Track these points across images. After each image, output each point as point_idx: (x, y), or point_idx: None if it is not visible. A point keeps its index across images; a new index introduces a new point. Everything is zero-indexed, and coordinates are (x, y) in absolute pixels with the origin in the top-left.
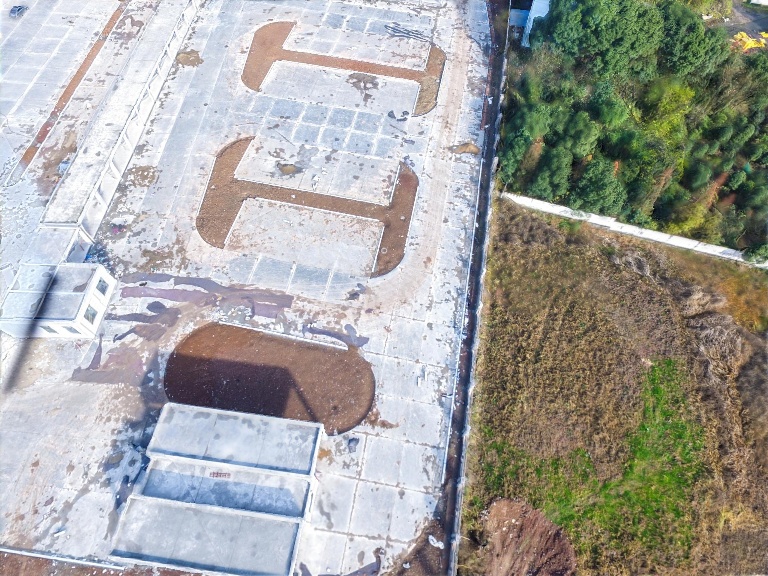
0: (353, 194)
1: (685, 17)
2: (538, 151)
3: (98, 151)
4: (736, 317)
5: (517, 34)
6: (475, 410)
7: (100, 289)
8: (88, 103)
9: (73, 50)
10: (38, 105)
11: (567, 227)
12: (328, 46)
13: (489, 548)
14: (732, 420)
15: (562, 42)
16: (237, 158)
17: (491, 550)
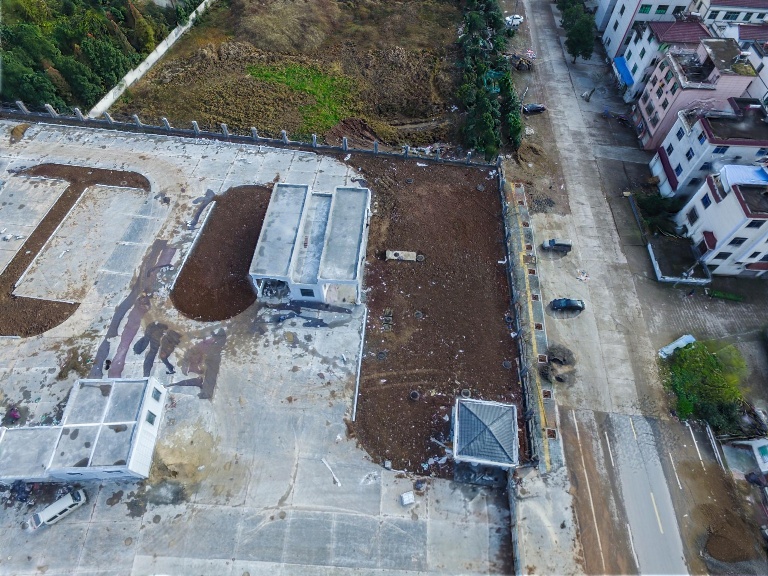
0: (45, 207)
1: None
2: (56, 71)
3: None
4: None
5: None
6: None
7: None
8: None
9: None
10: None
11: (129, 99)
12: None
13: None
14: None
15: None
16: None
17: None
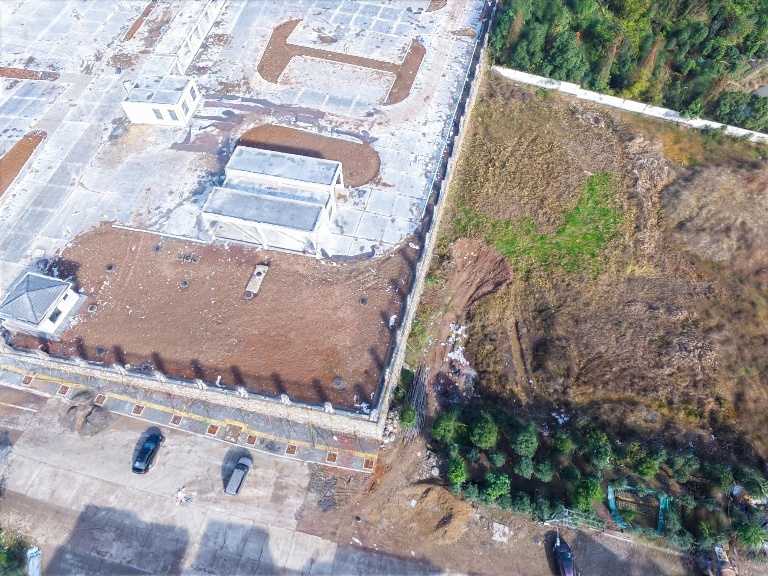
0: (375, 56)
1: None
2: (518, 25)
3: (190, 15)
4: (669, 157)
5: None
6: (452, 187)
7: (191, 95)
8: None
9: None
10: None
11: (542, 94)
12: None
13: (453, 267)
14: (650, 215)
15: None
16: (289, 31)
17: (454, 268)
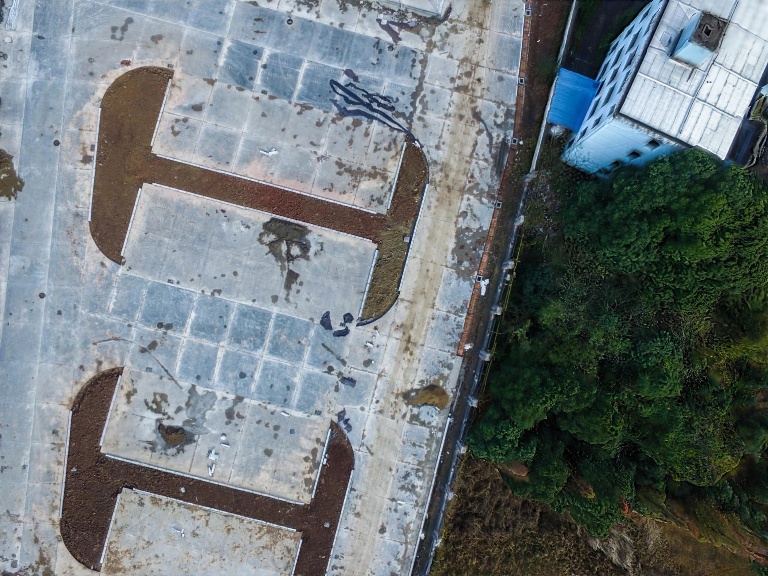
0: (263, 484)
1: None
2: None
3: None
4: None
5: None
6: None
7: None
8: None
9: None
10: None
11: None
12: (229, 145)
13: None
14: None
15: None
16: (101, 416)
17: None
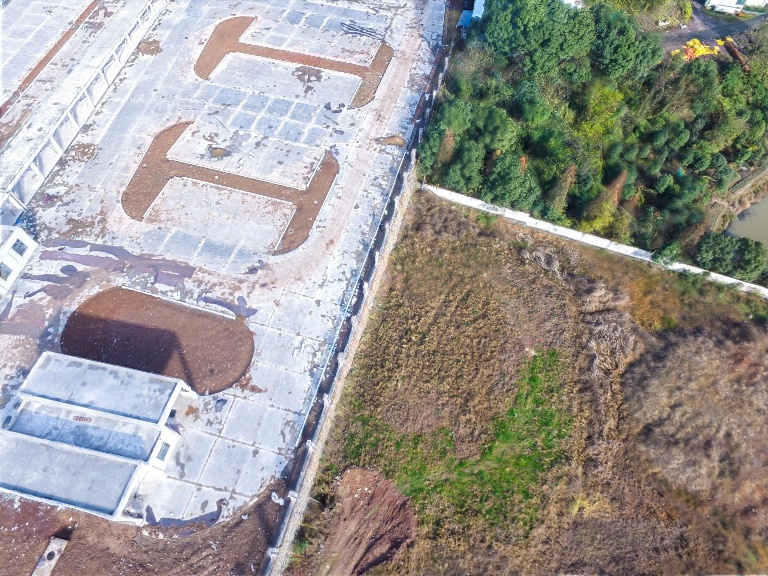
0: (273, 178)
1: (615, 20)
2: (450, 144)
3: (40, 127)
4: (636, 316)
5: (465, 34)
6: (347, 383)
7: (17, 250)
8: (48, 85)
9: (46, 37)
10: (4, 85)
11: (484, 221)
12: (282, 40)
13: (338, 512)
14: (608, 414)
15: (494, 41)
16: (172, 140)
17: (340, 514)
